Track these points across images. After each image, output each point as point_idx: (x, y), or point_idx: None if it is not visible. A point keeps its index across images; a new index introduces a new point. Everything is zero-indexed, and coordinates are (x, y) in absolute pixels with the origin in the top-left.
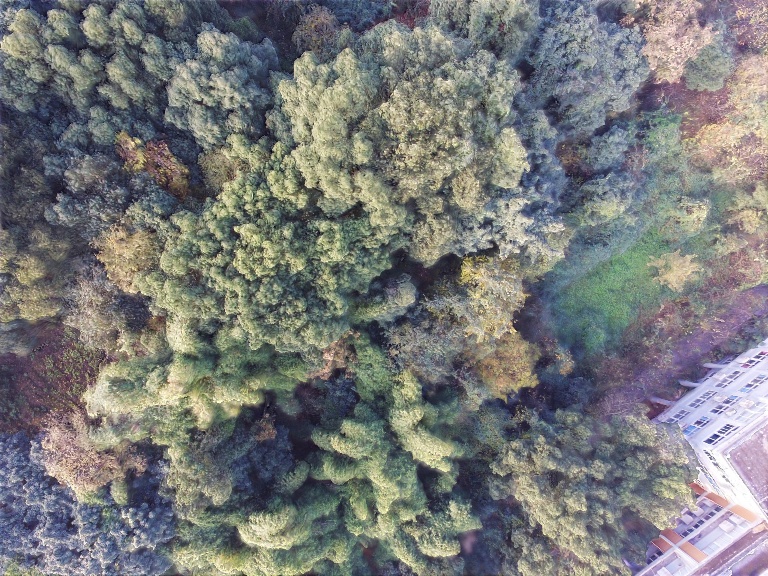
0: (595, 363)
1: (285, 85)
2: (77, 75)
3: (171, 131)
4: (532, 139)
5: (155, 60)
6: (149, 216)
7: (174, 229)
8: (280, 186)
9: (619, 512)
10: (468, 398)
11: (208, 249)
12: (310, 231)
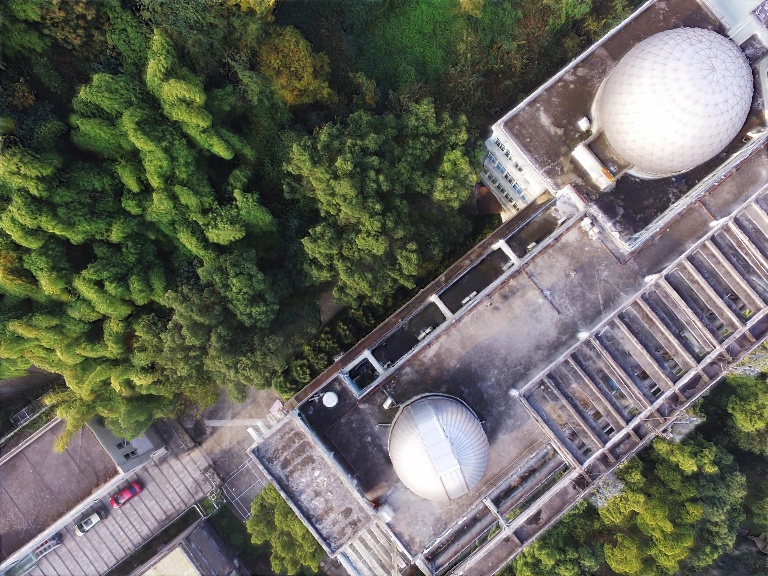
0: None
1: None
2: None
3: None
4: None
5: None
6: None
7: None
8: None
9: (400, 186)
10: (243, 84)
11: None
12: None
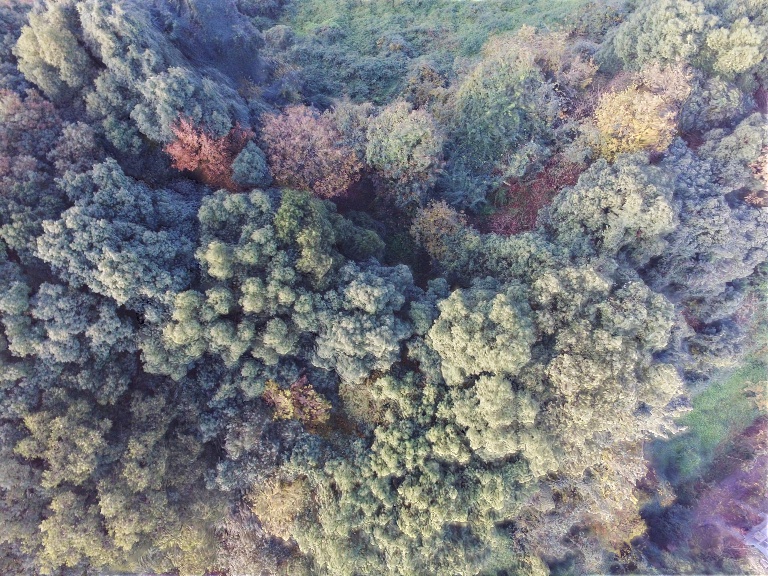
0: (688, 482)
1: (439, 335)
2: (237, 351)
3: (310, 363)
4: (671, 342)
5: (308, 320)
6: (304, 469)
7: (327, 477)
8: (444, 448)
9: None
10: (585, 560)
11: (371, 510)
12: (466, 475)
